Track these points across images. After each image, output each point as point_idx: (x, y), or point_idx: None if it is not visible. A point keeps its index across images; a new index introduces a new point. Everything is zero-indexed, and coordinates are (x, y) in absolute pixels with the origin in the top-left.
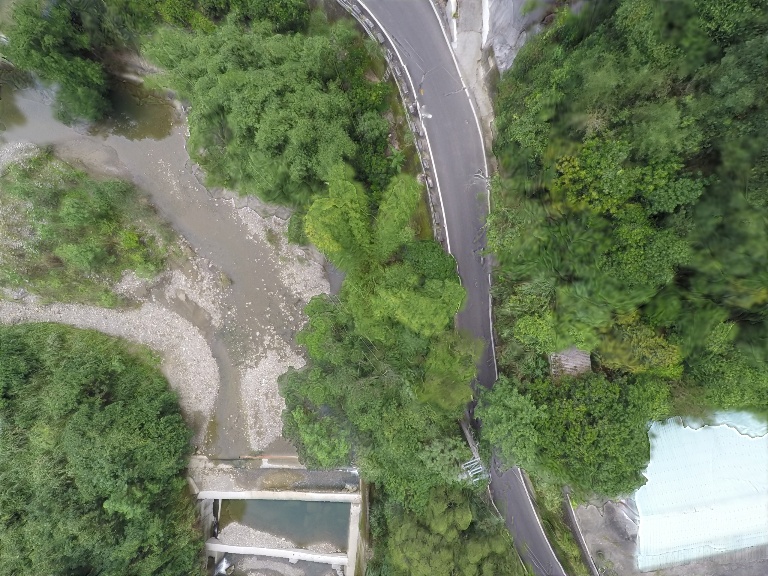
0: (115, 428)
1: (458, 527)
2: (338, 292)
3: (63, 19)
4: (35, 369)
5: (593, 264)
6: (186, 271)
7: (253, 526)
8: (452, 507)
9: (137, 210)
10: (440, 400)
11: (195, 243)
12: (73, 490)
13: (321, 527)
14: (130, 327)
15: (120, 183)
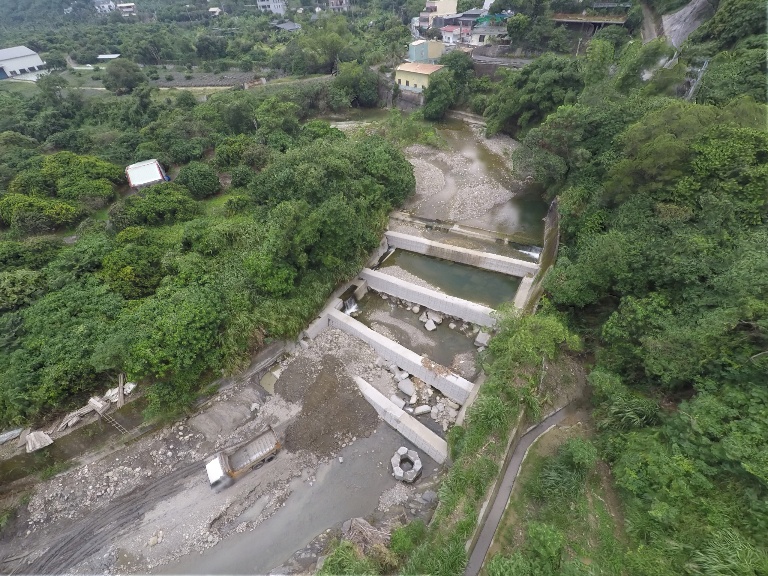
0: None
1: None
2: None
3: (453, 84)
4: None
5: None
6: (447, 154)
7: (412, 273)
8: None
9: None
10: None
11: None
12: None
13: (481, 294)
14: None
15: None
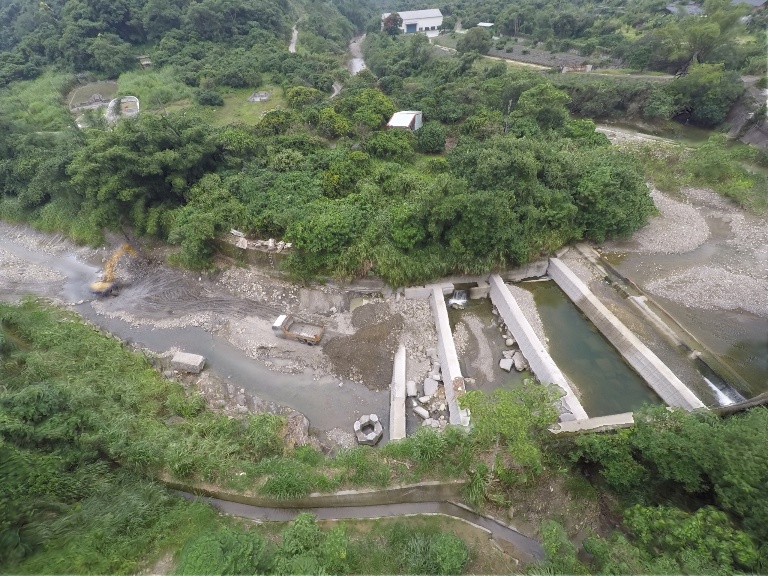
0: None
1: None
2: None
3: None
4: None
5: None
6: (749, 219)
7: (539, 310)
8: None
9: None
10: None
11: None
12: None
13: (590, 380)
14: (659, 201)
15: None
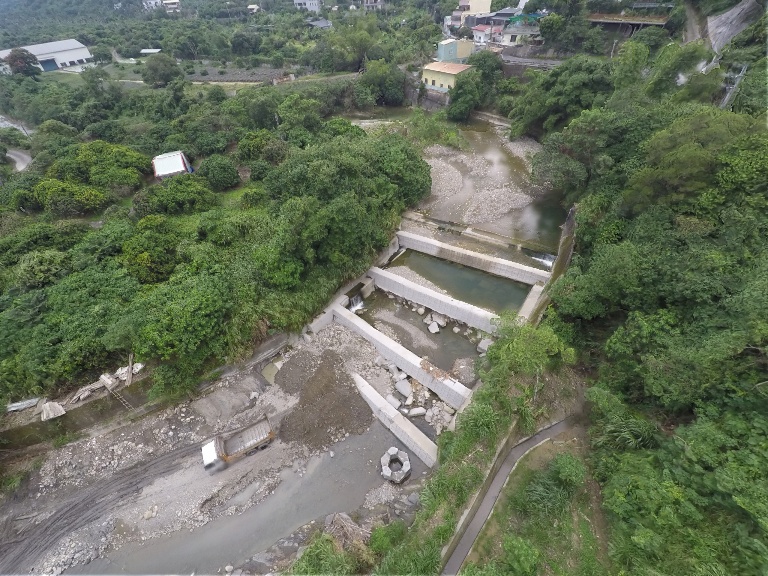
0: None
1: None
2: None
3: None
4: None
5: None
6: None
7: (421, 274)
8: None
9: None
10: None
11: None
12: None
13: (488, 300)
14: None
15: None
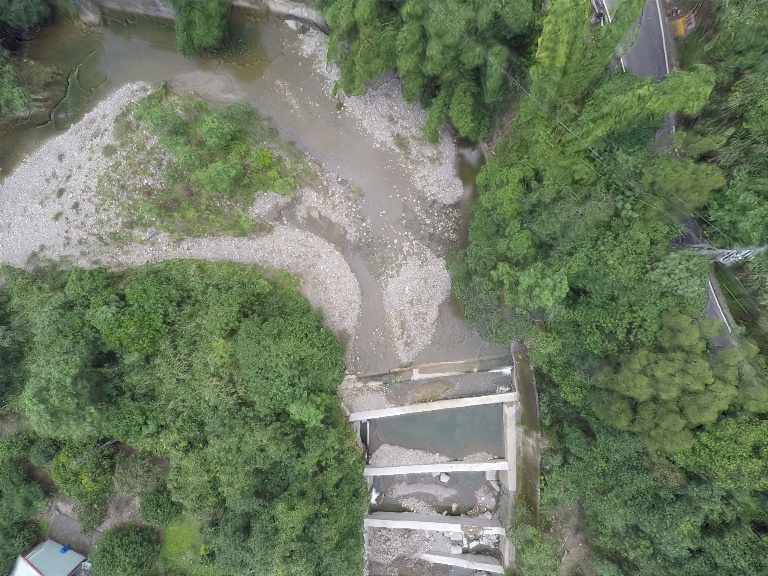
0: (284, 338)
1: (707, 337)
2: (470, 190)
3: None
4: (182, 299)
5: None
6: (316, 187)
7: (404, 445)
8: (695, 320)
9: (261, 131)
10: (692, 195)
11: (321, 159)
12: (246, 408)
13: (473, 437)
14: (263, 253)
15: (244, 104)
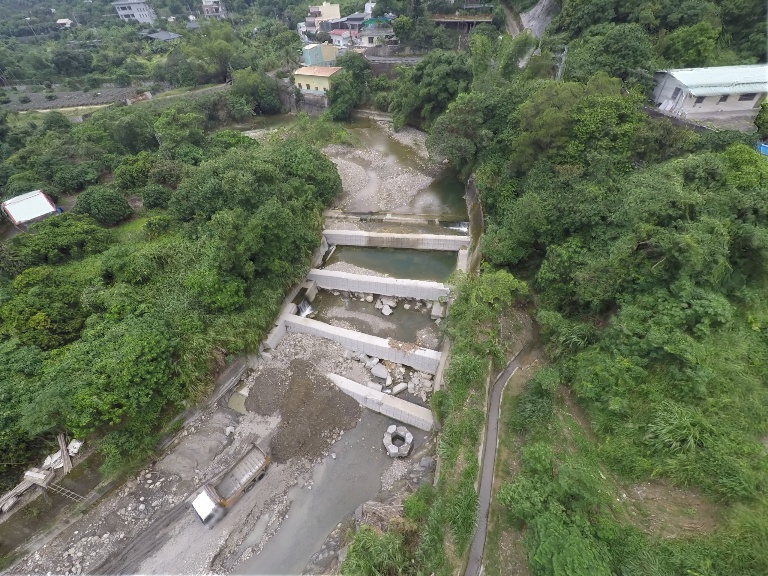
0: None
1: None
2: None
3: None
4: None
5: (588, 2)
6: None
7: (359, 266)
8: None
9: None
10: None
11: None
12: None
13: (426, 273)
14: None
15: None
